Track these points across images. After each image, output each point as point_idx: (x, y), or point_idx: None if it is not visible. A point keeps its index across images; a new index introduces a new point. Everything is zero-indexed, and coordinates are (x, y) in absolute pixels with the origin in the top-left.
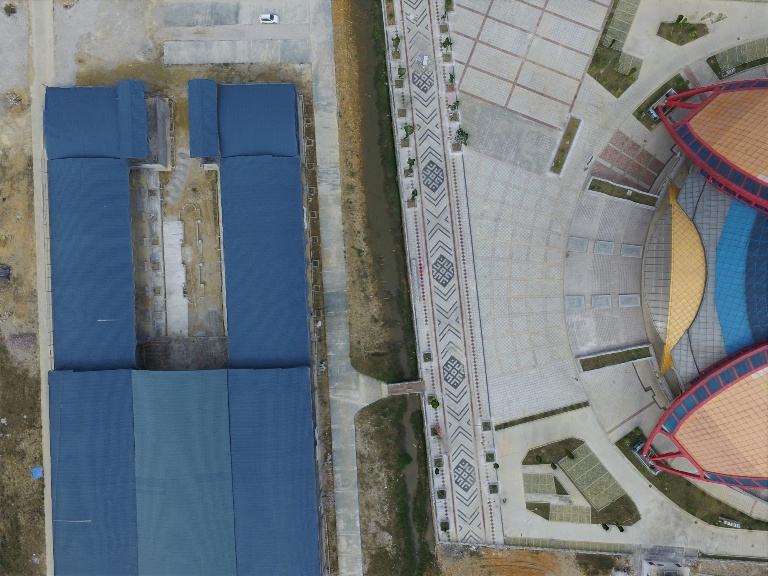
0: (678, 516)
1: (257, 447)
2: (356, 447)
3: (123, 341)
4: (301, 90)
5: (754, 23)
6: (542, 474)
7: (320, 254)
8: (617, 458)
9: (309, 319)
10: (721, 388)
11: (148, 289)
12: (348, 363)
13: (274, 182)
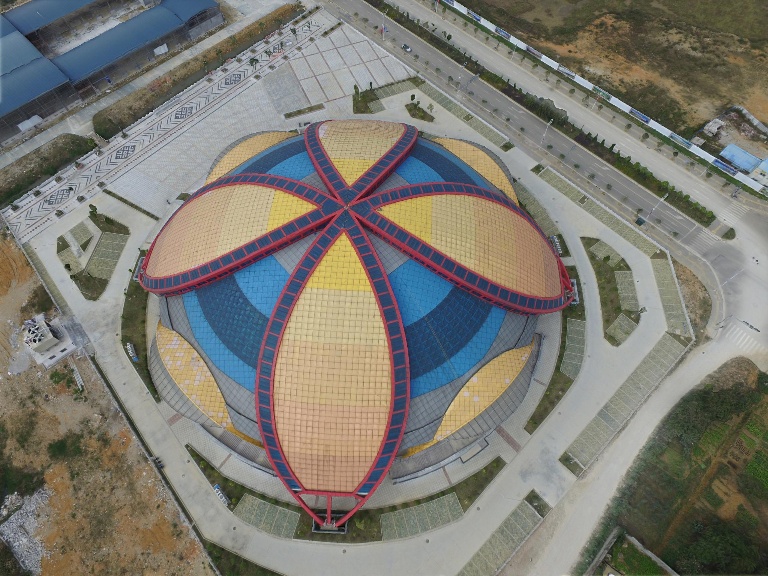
0: (114, 321)
1: (4, 85)
2: (43, 145)
3: (33, 24)
4: (230, 20)
5: (462, 135)
6: (89, 230)
7: (150, 70)
8: (132, 259)
9: (103, 77)
10: (189, 200)
11: (75, 31)
12: (95, 113)
13: (162, 21)
